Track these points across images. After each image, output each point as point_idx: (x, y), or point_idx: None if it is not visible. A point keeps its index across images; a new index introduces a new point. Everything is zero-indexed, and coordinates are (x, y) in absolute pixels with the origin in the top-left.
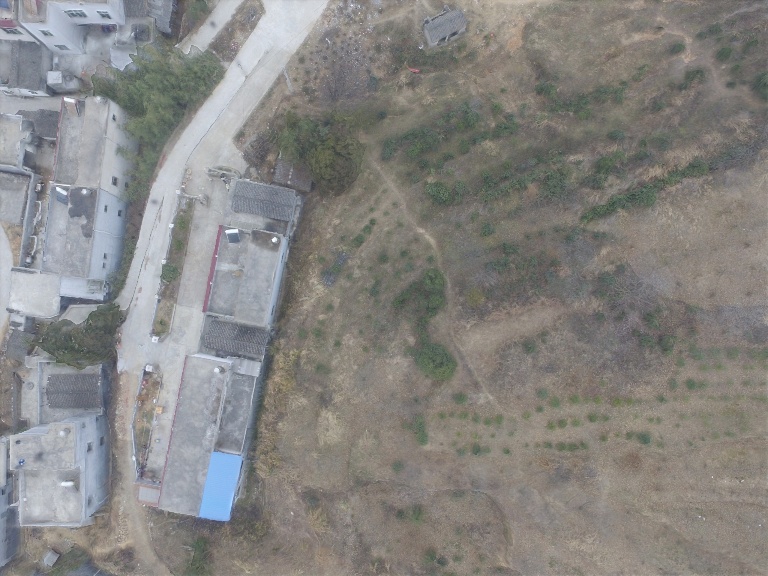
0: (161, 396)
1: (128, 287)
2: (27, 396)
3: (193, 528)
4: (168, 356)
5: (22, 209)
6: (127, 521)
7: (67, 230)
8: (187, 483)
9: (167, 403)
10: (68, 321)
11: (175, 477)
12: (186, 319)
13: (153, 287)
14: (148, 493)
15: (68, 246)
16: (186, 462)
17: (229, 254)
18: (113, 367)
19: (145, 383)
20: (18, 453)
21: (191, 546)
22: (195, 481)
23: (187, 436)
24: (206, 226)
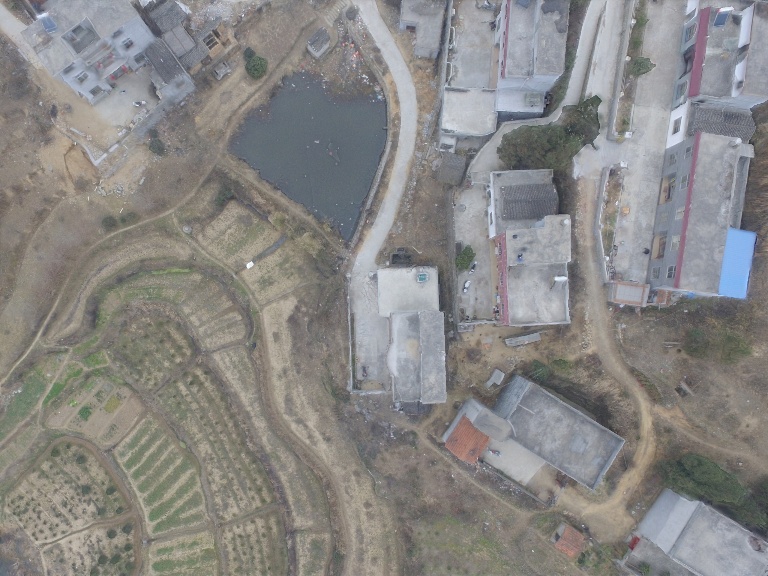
0: (622, 198)
1: (568, 98)
2: (459, 219)
3: (677, 322)
4: (627, 157)
5: (441, 33)
6: (591, 327)
7: (541, 26)
8: (704, 261)
9: (629, 205)
10: (529, 126)
11: (691, 255)
12: (644, 119)
13: (603, 91)
14: (626, 291)
15: (543, 42)
16: (702, 240)
17: (713, 37)
18: (566, 175)
19: (608, 185)
20: (517, 247)
21: (675, 341)
22: (712, 258)
23: (702, 213)
24: (660, 24)
